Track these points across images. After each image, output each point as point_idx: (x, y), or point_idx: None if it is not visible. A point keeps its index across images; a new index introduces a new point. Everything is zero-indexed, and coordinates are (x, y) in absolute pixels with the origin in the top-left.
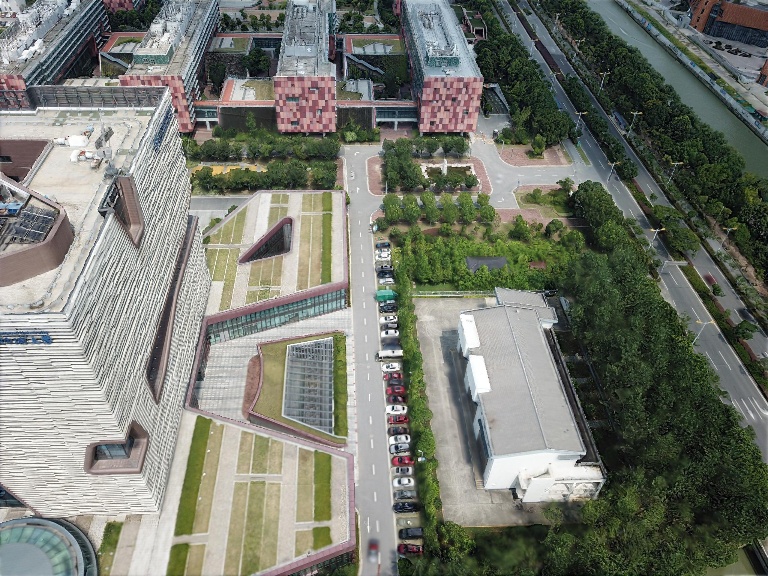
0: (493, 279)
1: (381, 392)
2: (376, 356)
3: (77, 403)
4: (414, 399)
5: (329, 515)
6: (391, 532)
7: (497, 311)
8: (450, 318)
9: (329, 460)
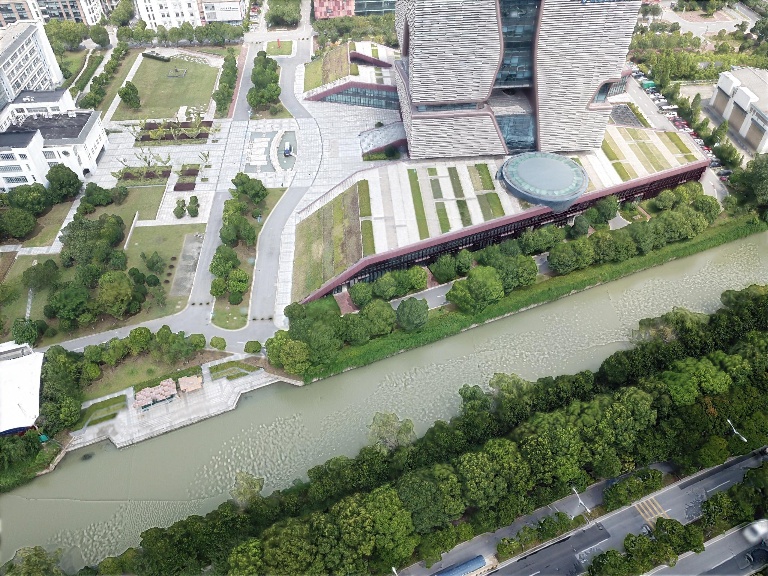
0: (717, 72)
1: (671, 125)
2: (660, 110)
3: (615, 48)
4: (697, 124)
5: (690, 151)
6: (712, 175)
7: (743, 70)
8: (695, 94)
9: (675, 134)
